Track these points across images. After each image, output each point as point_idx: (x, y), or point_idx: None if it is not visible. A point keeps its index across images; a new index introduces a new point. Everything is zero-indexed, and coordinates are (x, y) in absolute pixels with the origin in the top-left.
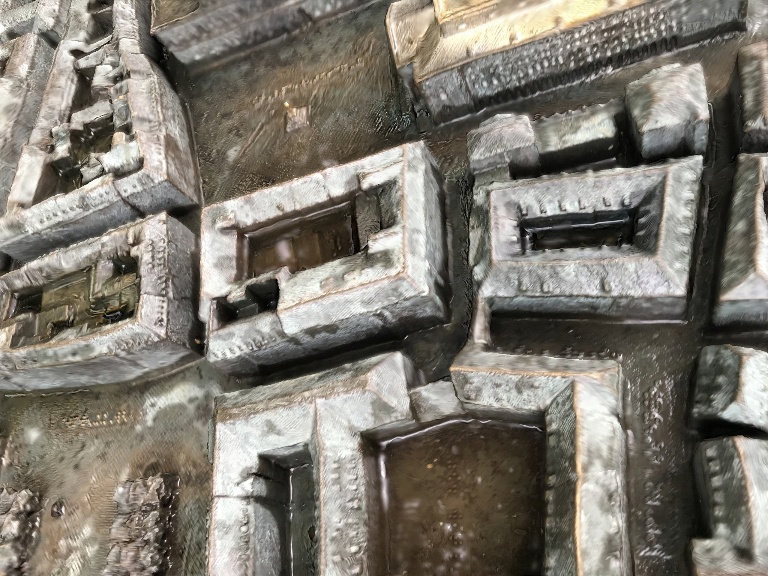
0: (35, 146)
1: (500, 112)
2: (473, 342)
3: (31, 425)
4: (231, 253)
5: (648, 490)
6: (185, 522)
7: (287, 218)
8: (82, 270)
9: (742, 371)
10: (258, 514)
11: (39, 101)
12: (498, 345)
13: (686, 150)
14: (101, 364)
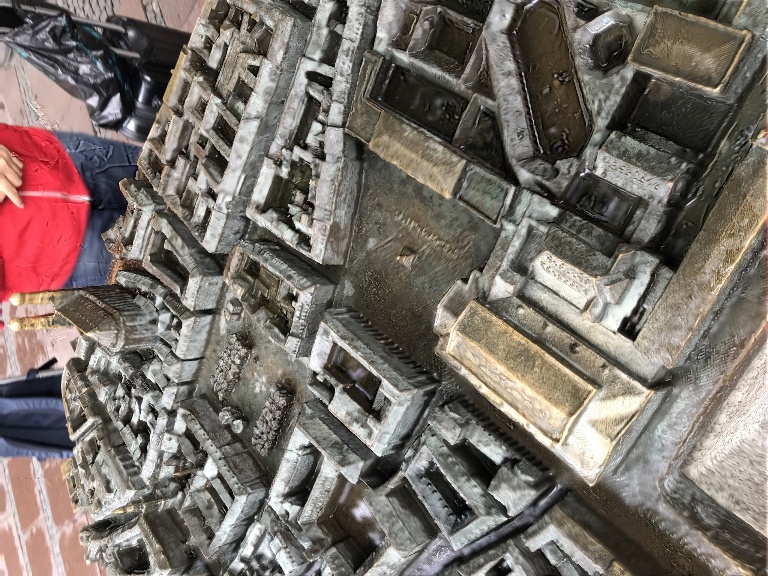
0: (271, 159)
1: None
2: (387, 485)
3: None
4: (327, 351)
5: (419, 568)
6: (293, 415)
7: None
8: None
9: None
10: (303, 458)
11: (289, 78)
12: None
13: None
14: None
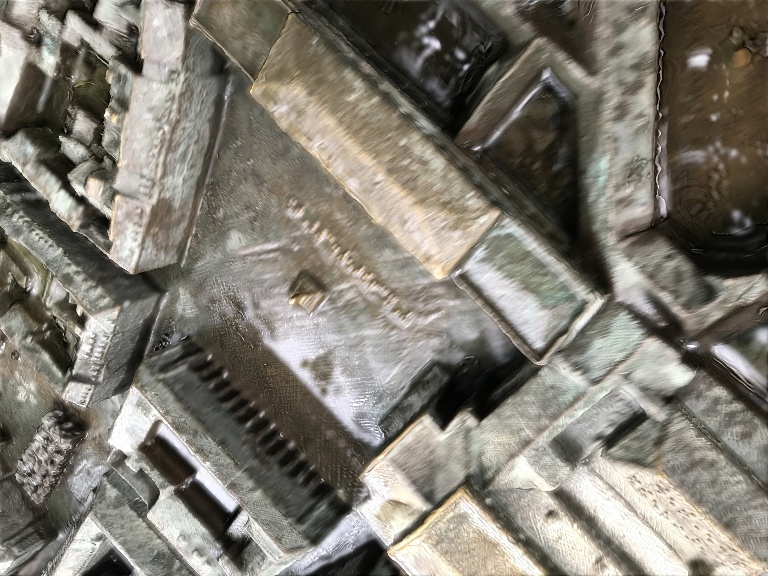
0: (14, 27)
1: None
2: None
3: None
4: (145, 427)
5: None
6: (85, 454)
7: None
8: None
9: None
10: None
11: None
12: None
13: None
14: None
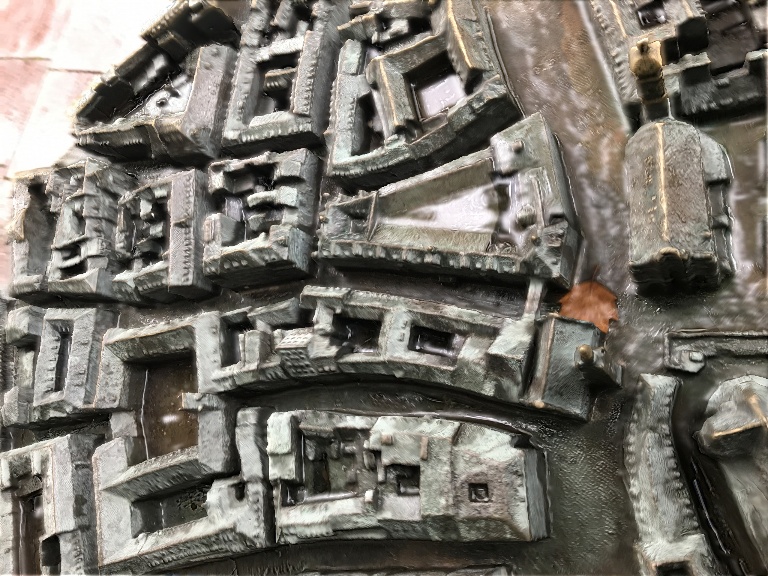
0: None
1: None
2: None
3: None
4: None
5: None
6: None
7: (18, 550)
8: None
9: (116, 281)
10: None
11: None
12: None
13: None
14: None
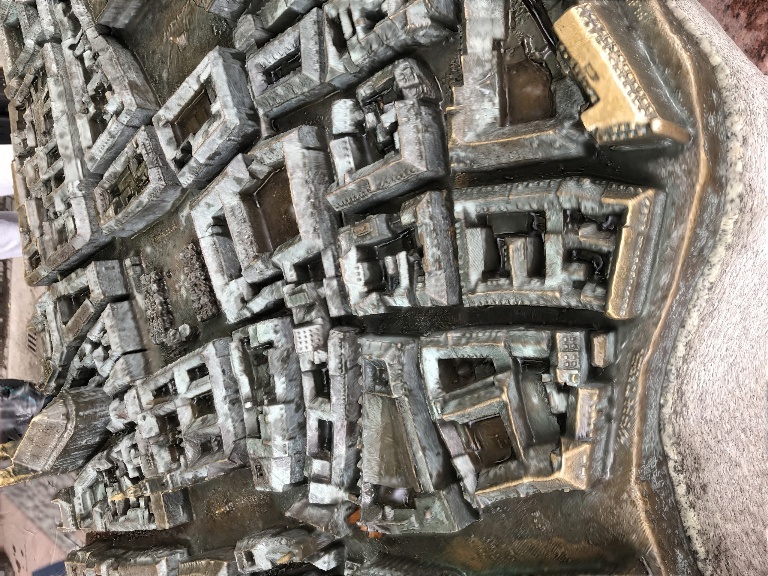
0: (79, 113)
1: (258, 2)
2: (262, 137)
3: (146, 246)
4: (171, 135)
5: None
6: None
7: (186, 108)
8: (126, 168)
9: (332, 113)
10: (220, 240)
11: None
12: (284, 131)
13: (318, 2)
14: (151, 207)
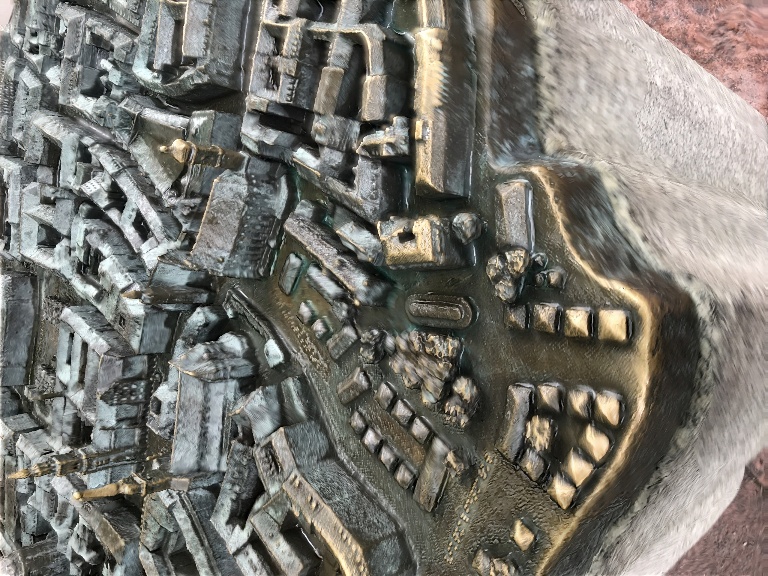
0: None
1: None
2: None
3: (37, 371)
4: (0, 241)
5: None
6: None
7: (3, 217)
8: None
9: (46, 75)
10: None
11: None
12: None
13: None
14: (14, 313)
